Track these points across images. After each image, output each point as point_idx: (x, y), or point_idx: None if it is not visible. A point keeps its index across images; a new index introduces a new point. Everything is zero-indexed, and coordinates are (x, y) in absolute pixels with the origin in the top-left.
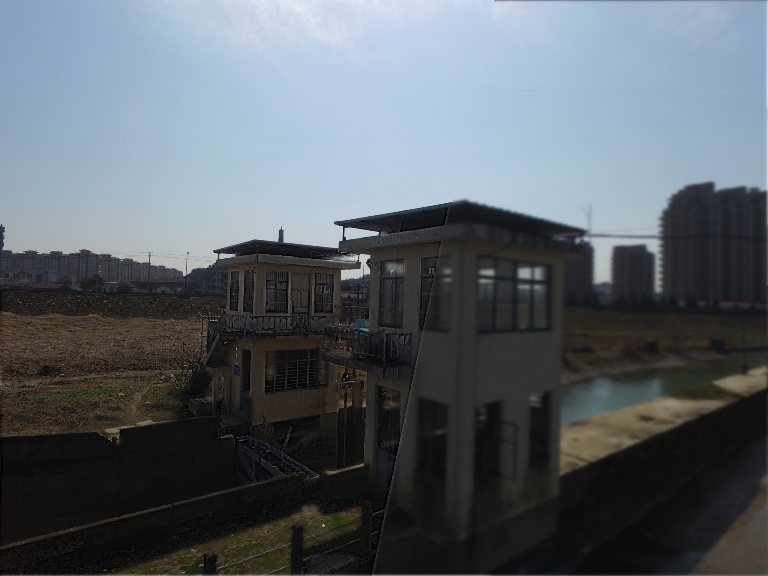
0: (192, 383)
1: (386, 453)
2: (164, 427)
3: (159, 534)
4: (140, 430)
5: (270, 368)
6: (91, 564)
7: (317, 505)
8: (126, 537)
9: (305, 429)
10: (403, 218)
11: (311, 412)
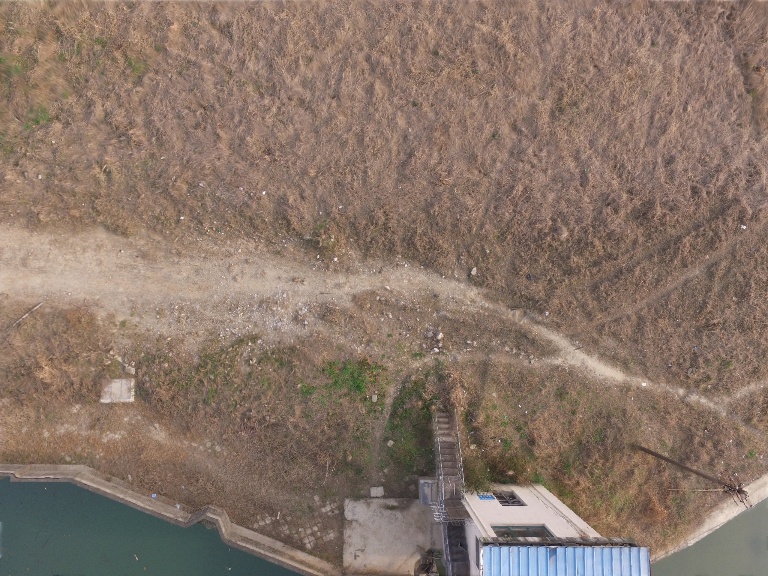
0: None
1: None
2: None
3: None
4: None
5: None
6: None
7: None
8: None
9: None
10: None
11: None
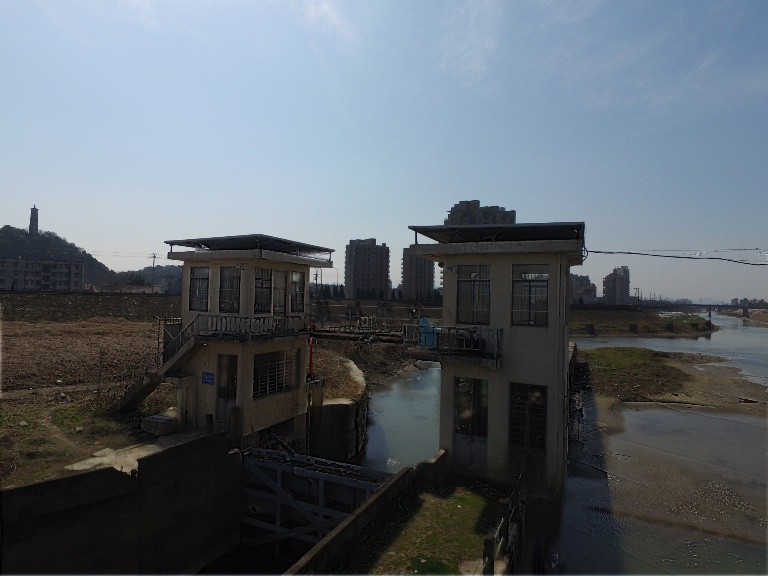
0: (129, 399)
1: (468, 436)
2: (181, 450)
3: (352, 547)
4: (159, 457)
5: (255, 373)
6: None
7: (427, 493)
8: (335, 556)
9: (280, 434)
10: (503, 230)
11: (287, 415)
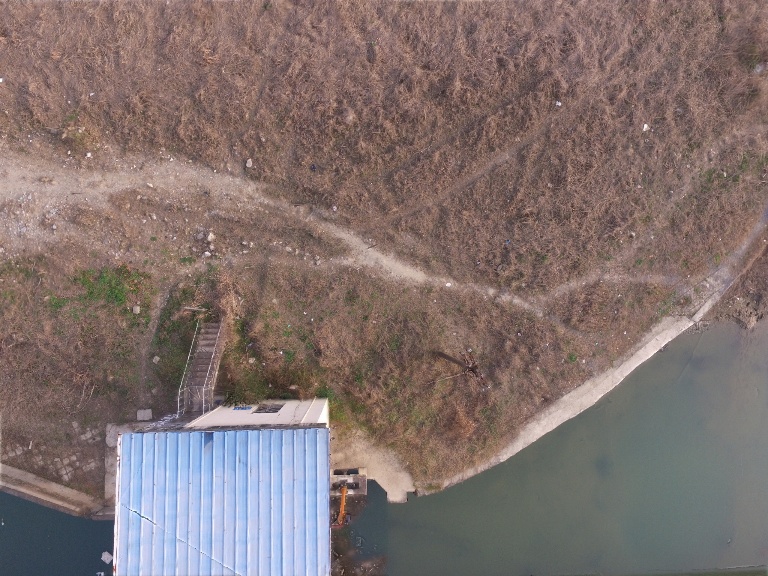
0: None
1: None
2: None
3: None
4: None
5: None
6: None
7: None
8: None
9: None
10: None
11: None
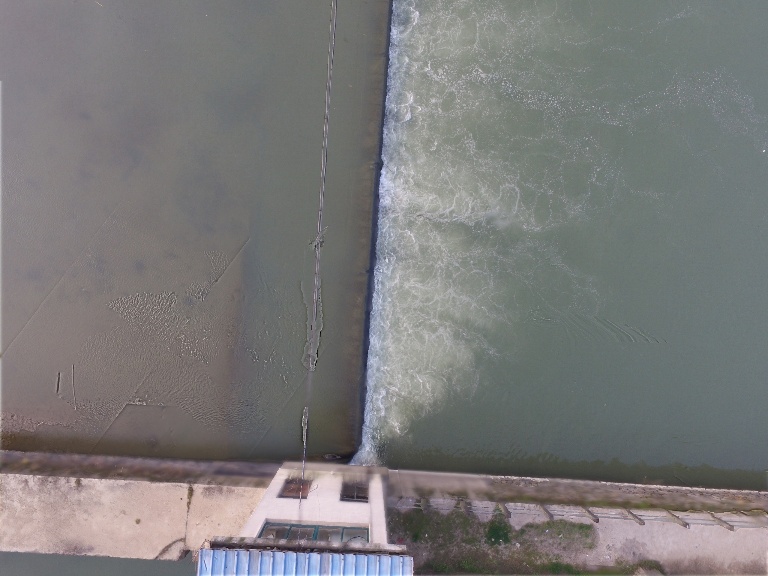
0: None
1: None
2: None
3: None
4: None
5: None
6: (533, 574)
7: (415, 560)
8: None
9: None
10: None
11: None
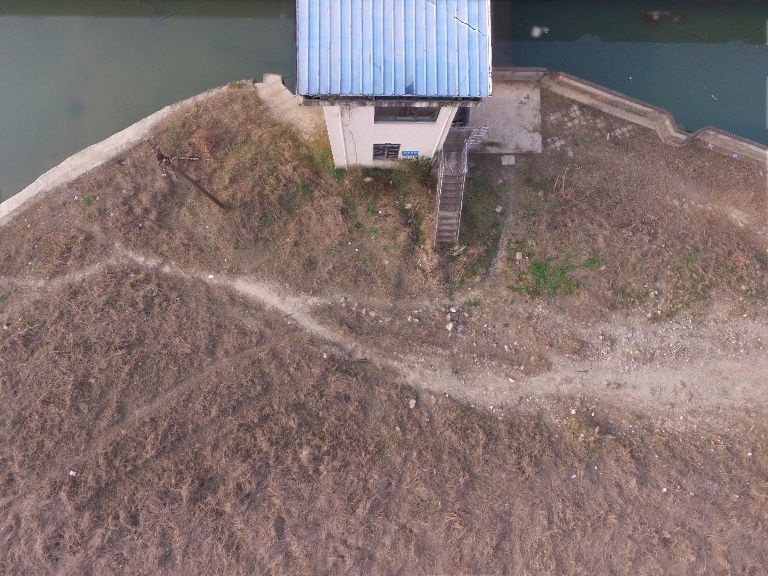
0: None
1: None
2: None
3: None
4: None
5: None
6: None
7: None
8: None
9: None
10: None
11: None
